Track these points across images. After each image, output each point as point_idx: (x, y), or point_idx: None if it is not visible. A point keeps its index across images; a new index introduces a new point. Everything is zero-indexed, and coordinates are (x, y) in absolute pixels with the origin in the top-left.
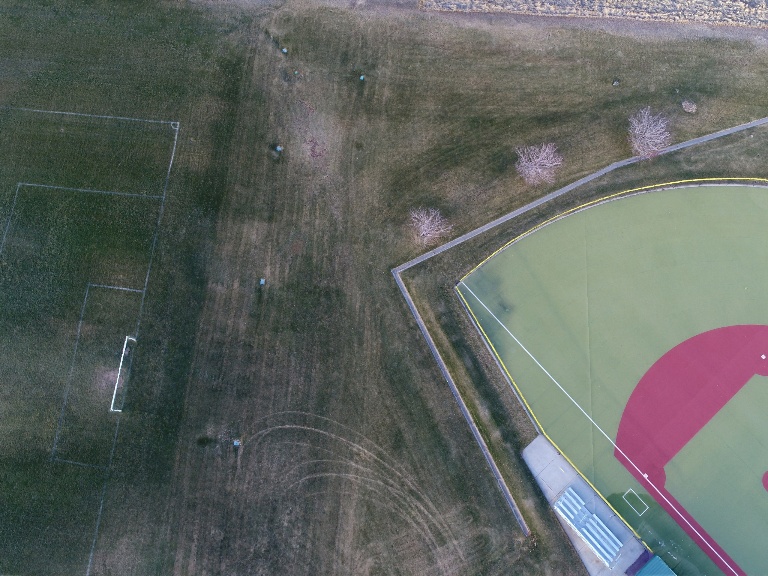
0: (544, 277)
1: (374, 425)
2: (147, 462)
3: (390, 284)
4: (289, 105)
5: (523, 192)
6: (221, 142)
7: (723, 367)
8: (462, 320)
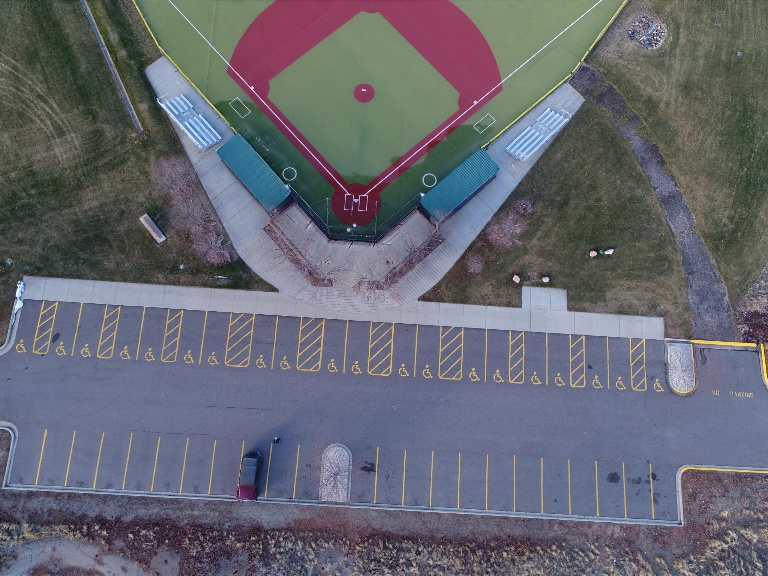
0: None
1: (13, 45)
2: None
3: None
4: None
5: None
6: None
7: (334, 5)
8: None
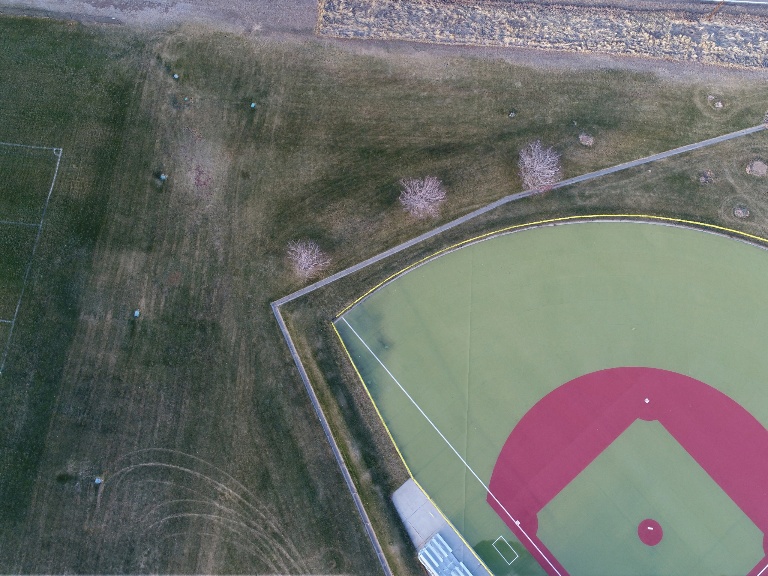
0: (426, 313)
1: (241, 464)
2: (3, 499)
3: (268, 318)
4: (176, 132)
5: (411, 225)
6: (104, 169)
7: (605, 411)
8: (339, 357)
